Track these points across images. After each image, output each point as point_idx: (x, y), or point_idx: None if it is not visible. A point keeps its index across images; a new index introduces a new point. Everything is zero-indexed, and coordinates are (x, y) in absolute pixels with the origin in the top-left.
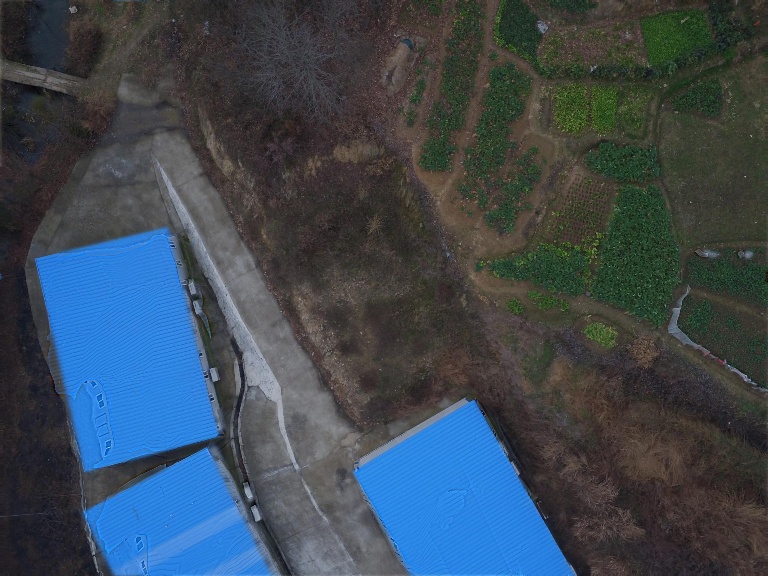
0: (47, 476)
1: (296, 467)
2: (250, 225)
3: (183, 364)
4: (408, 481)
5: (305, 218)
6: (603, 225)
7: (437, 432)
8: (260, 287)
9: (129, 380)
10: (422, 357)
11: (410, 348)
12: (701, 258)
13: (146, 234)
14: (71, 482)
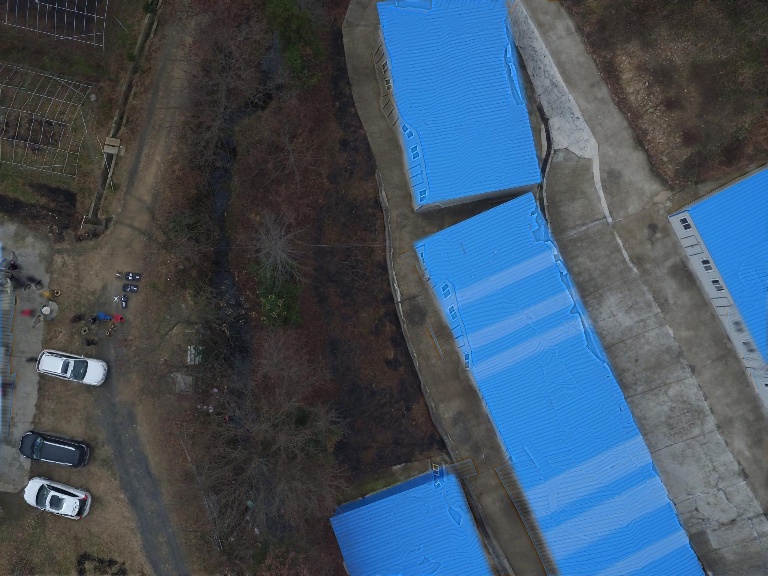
0: (352, 227)
1: (609, 220)
2: None
3: (496, 122)
4: (739, 222)
5: None
6: None
7: (766, 179)
8: (579, 50)
9: (447, 132)
10: (742, 117)
11: (731, 107)
12: None
13: None
14: (376, 233)
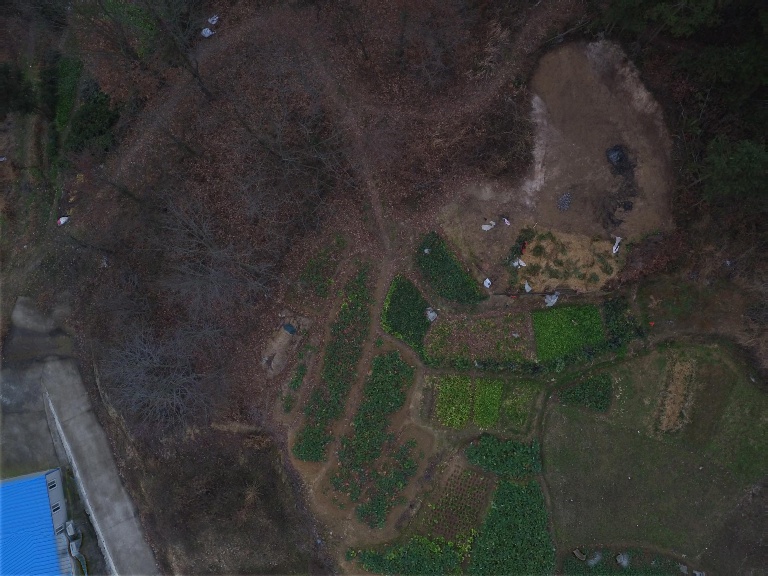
0: None
1: None
2: (131, 473)
3: None
4: None
5: (183, 478)
6: (479, 523)
7: None
8: (137, 537)
9: None
10: None
11: None
12: (578, 561)
13: (30, 465)
14: None
